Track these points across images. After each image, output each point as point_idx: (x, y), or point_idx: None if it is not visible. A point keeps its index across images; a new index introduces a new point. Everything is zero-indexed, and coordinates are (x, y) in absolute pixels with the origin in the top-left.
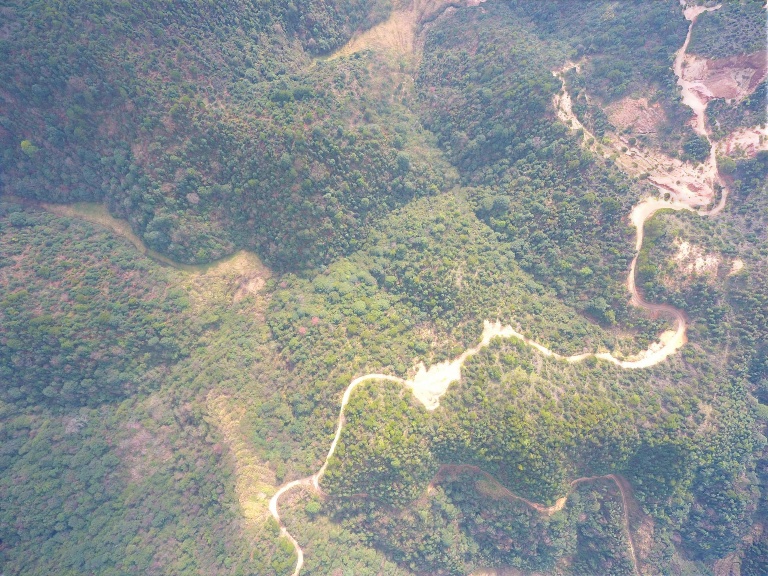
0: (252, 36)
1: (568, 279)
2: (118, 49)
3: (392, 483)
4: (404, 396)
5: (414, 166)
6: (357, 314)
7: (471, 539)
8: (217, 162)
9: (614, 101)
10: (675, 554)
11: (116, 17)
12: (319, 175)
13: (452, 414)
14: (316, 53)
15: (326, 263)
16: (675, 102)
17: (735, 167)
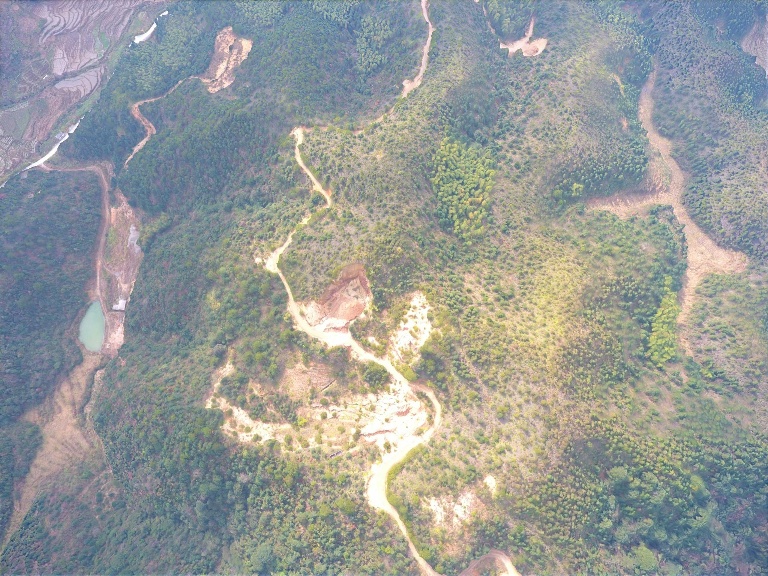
0: None
1: None
2: None
3: None
4: None
5: None
6: None
7: None
8: None
9: (280, 378)
10: None
11: None
12: None
13: None
14: None
15: None
16: (321, 356)
17: (415, 374)
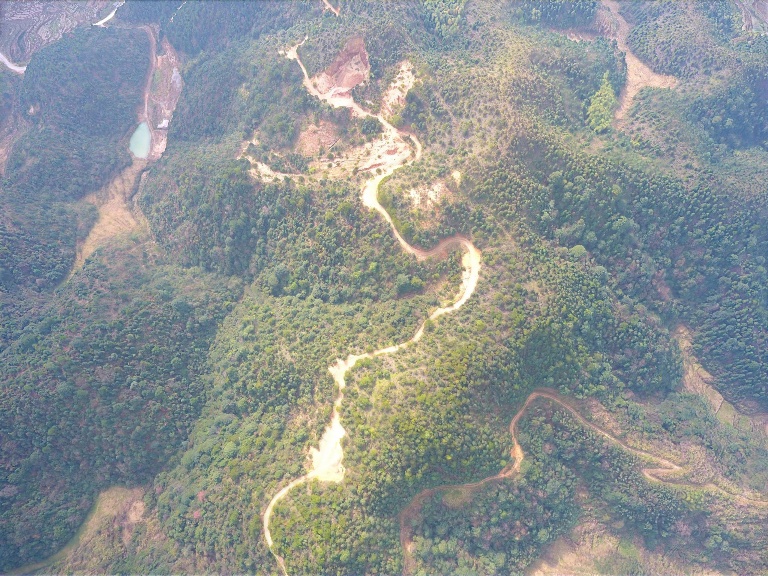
0: None
1: (369, 283)
2: None
3: (364, 575)
4: (311, 490)
5: (195, 302)
6: (232, 457)
7: (490, 554)
8: (8, 442)
9: (296, 142)
10: (648, 406)
11: None
12: (109, 376)
13: (358, 467)
14: (52, 286)
15: (185, 438)
16: (329, 111)
17: (402, 118)
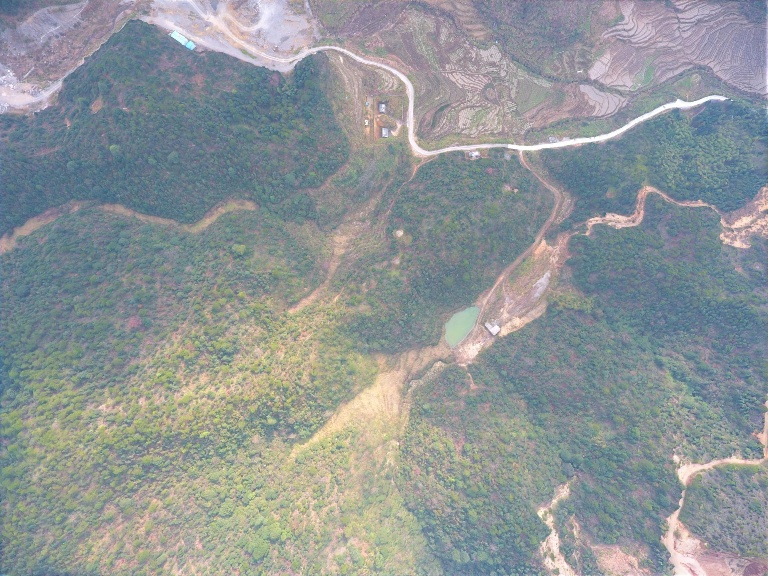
0: (228, 460)
1: None
2: (82, 546)
3: None
4: None
5: None
6: None
7: None
8: None
9: (604, 544)
10: None
11: (80, 512)
12: None
13: None
14: (297, 439)
15: None
16: None
17: None
